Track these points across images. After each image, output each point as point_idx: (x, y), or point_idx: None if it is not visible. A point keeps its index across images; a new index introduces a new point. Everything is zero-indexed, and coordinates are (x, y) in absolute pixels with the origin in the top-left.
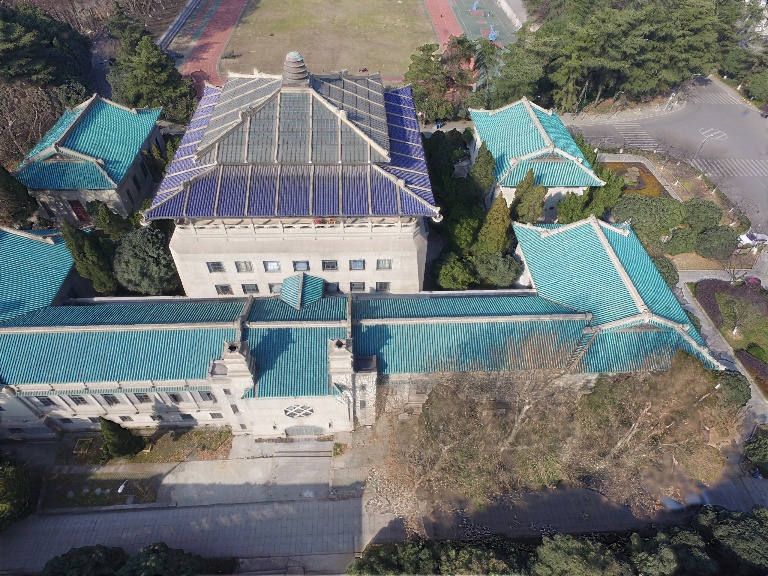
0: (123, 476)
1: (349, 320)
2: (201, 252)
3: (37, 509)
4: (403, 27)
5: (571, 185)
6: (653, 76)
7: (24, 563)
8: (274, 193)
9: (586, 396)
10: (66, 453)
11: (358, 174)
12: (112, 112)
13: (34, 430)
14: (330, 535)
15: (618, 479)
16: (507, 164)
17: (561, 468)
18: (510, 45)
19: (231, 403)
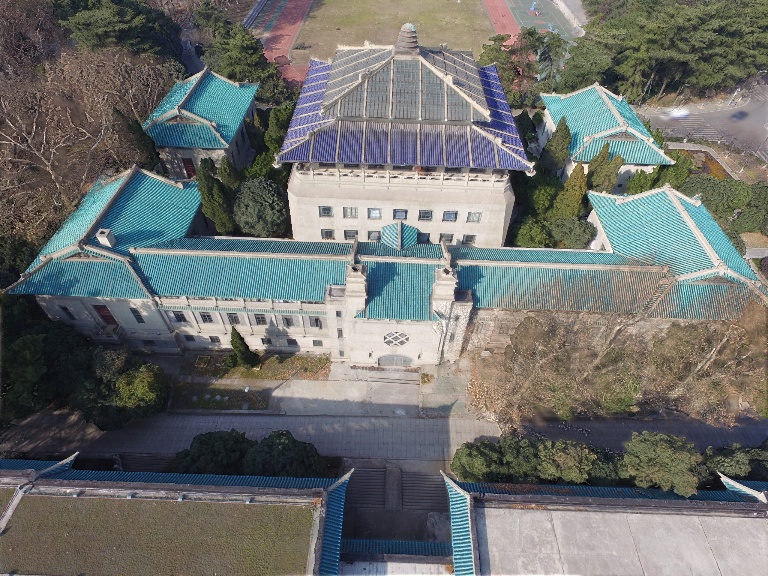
0: (238, 387)
1: (449, 257)
2: (316, 196)
3: (168, 408)
4: (463, 25)
5: (642, 163)
6: (719, 71)
7: (160, 449)
8: (386, 145)
9: (659, 341)
10: (189, 366)
11: (459, 133)
12: (219, 84)
13: (164, 344)
14: (422, 445)
15: (697, 398)
16: (580, 141)
17: (647, 380)
18: (578, 38)
19: (339, 327)
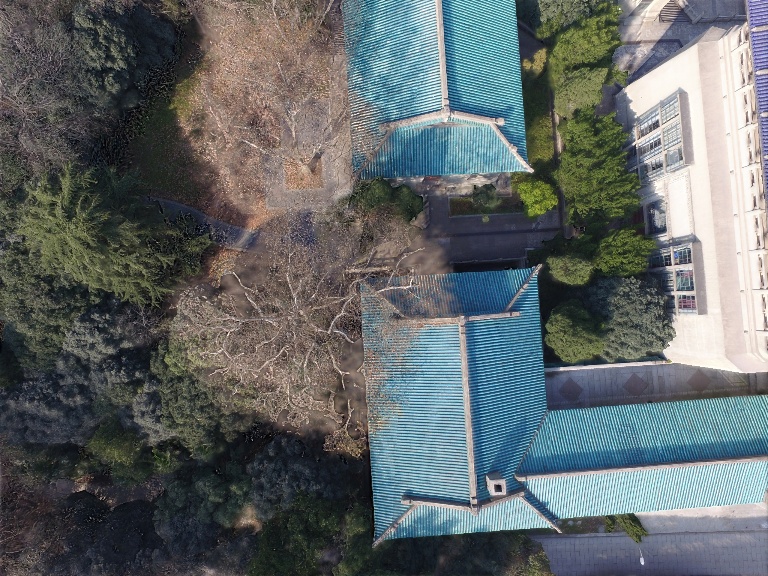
0: None
1: None
2: None
3: None
4: None
5: None
6: None
7: None
8: None
9: None
10: None
11: None
12: None
13: None
14: None
15: None
16: None
17: None
18: None
19: None
